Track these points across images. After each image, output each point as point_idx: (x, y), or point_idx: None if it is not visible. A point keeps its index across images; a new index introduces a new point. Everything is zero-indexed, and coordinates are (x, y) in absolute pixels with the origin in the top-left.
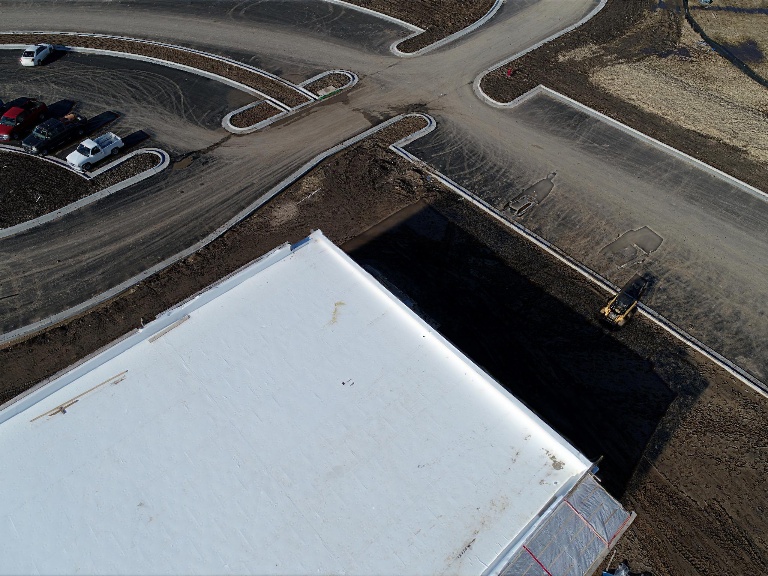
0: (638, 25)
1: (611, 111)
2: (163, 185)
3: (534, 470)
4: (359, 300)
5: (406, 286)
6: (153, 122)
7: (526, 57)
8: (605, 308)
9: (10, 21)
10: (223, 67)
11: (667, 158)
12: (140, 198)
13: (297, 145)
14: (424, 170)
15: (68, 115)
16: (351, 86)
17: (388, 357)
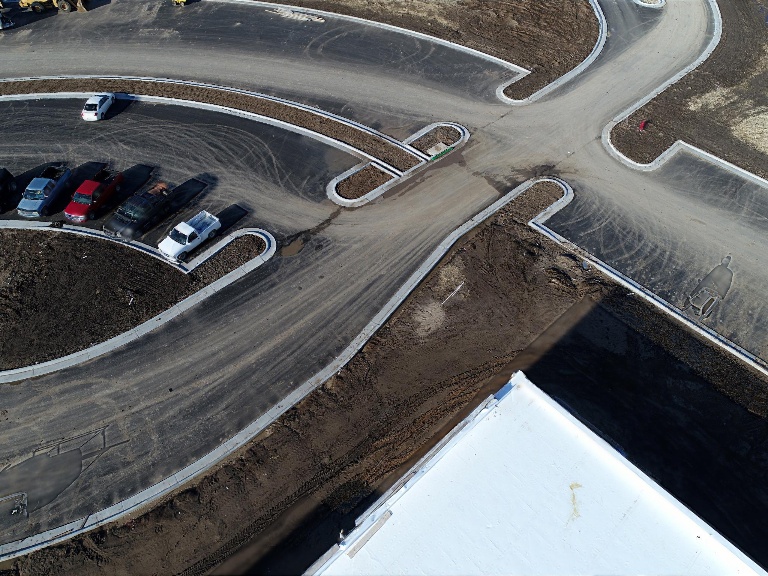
0: (762, 63)
1: None
2: (275, 279)
3: None
4: (599, 479)
5: (603, 422)
6: (247, 193)
7: (653, 105)
8: None
9: (59, 62)
10: (313, 119)
11: None
12: (252, 297)
13: (420, 222)
14: (577, 255)
15: (152, 189)
16: (463, 142)
17: (663, 573)
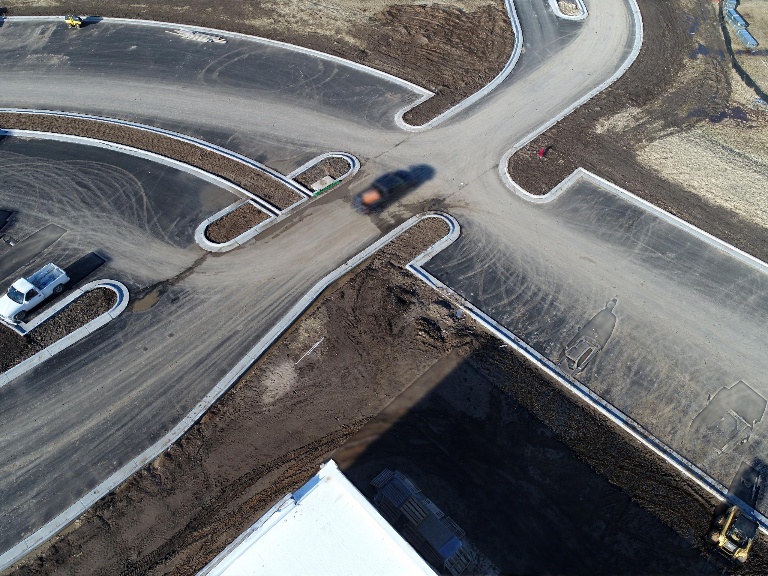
0: (680, 78)
1: (670, 204)
2: (120, 339)
3: None
4: None
5: (447, 502)
6: (108, 239)
7: (558, 128)
8: (719, 537)
9: None
10: (195, 153)
11: (749, 272)
12: (90, 361)
13: (290, 267)
14: (452, 302)
15: None
16: (352, 175)
17: None
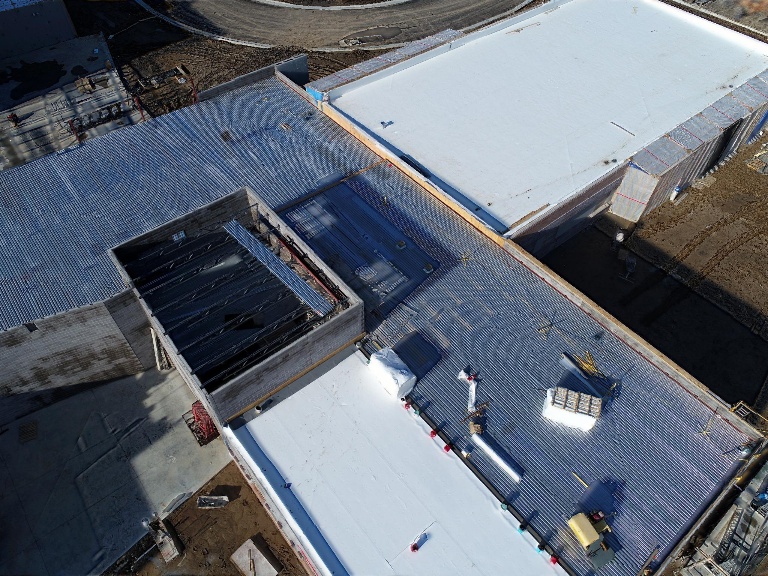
0: None
1: None
2: None
3: (760, 59)
4: (645, 6)
5: None
6: None
7: None
8: None
9: None
10: None
11: None
12: None
13: None
14: None
15: None
16: None
17: (671, 25)
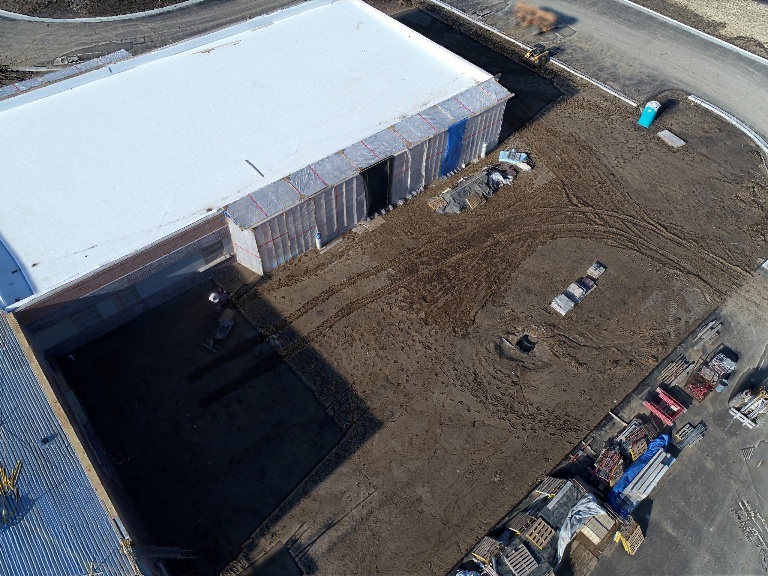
0: None
1: None
2: None
3: (464, 83)
4: (372, 22)
5: None
6: None
7: None
8: (527, 53)
9: None
10: None
11: None
12: (227, 2)
13: None
14: None
15: None
16: None
17: (388, 43)
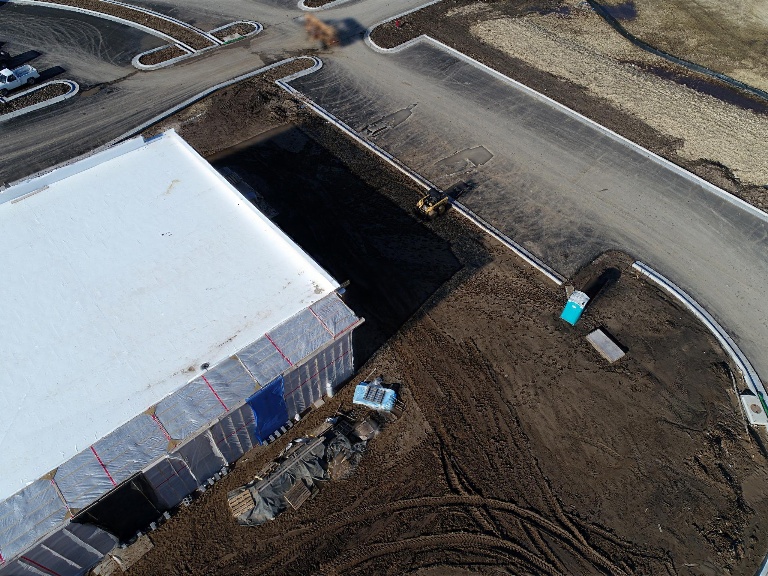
0: None
1: (480, 56)
2: (69, 108)
3: (298, 294)
4: (193, 179)
5: (258, 185)
6: (71, 59)
7: (418, 12)
8: (419, 201)
9: None
10: (143, 17)
11: (518, 94)
12: (47, 118)
13: (194, 79)
14: (301, 100)
15: None
16: (255, 34)
17: (205, 218)
